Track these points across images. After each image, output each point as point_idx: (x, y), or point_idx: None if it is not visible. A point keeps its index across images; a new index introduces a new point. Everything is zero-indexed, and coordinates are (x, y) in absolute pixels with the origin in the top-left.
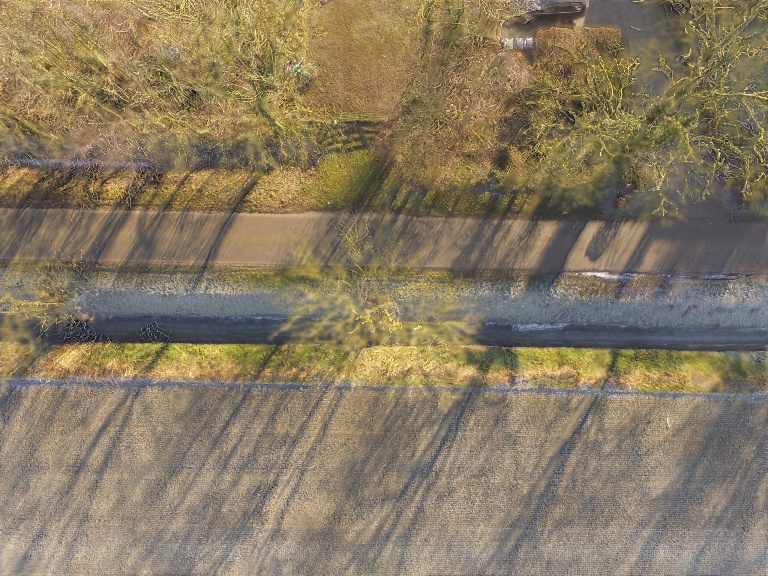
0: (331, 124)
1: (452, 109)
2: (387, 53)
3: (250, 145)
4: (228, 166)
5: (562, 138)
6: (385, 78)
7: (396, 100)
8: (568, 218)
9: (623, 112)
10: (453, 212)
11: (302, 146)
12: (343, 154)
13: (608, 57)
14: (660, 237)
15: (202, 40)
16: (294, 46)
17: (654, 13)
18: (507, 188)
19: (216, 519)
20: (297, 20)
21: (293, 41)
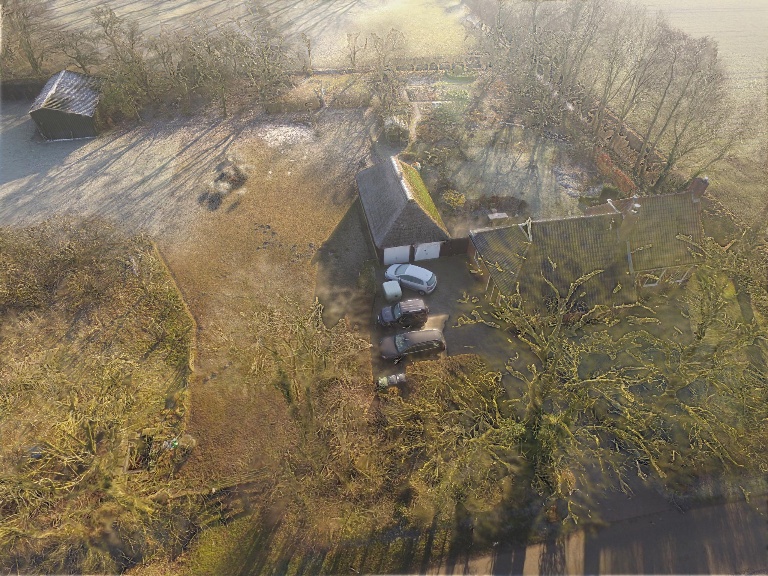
0: (208, 494)
1: (338, 451)
2: (270, 411)
3: (107, 540)
4: (73, 575)
5: (457, 457)
6: (269, 434)
7: (281, 453)
8: (501, 550)
9: (503, 420)
10: (362, 575)
11: (172, 527)
12: (221, 527)
13: (475, 376)
14: (616, 550)
15: (5, 431)
16: (174, 421)
17: (503, 338)
18: (419, 527)
19: None
20: (179, 398)
21: (173, 417)
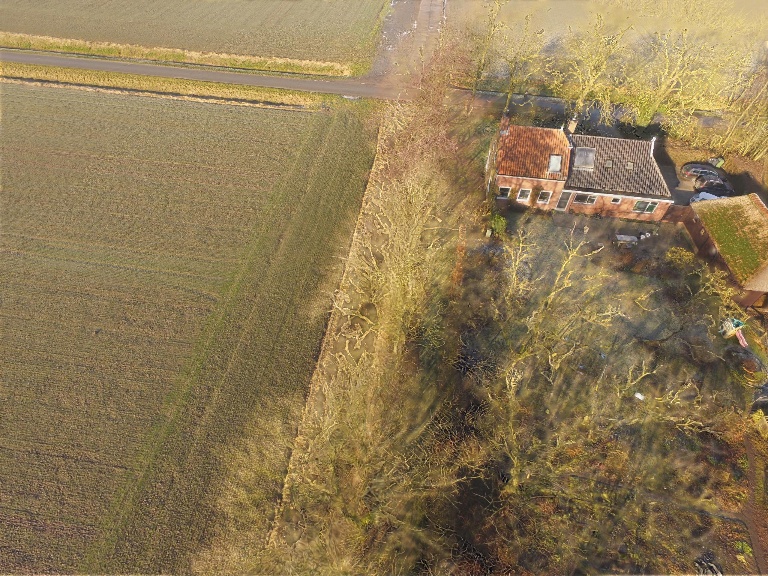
0: None
1: None
2: None
3: None
4: None
5: None
6: None
7: None
8: None
9: None
10: None
11: None
12: None
13: None
14: None
15: None
16: None
17: None
18: None
19: (762, 76)
20: None
21: None
